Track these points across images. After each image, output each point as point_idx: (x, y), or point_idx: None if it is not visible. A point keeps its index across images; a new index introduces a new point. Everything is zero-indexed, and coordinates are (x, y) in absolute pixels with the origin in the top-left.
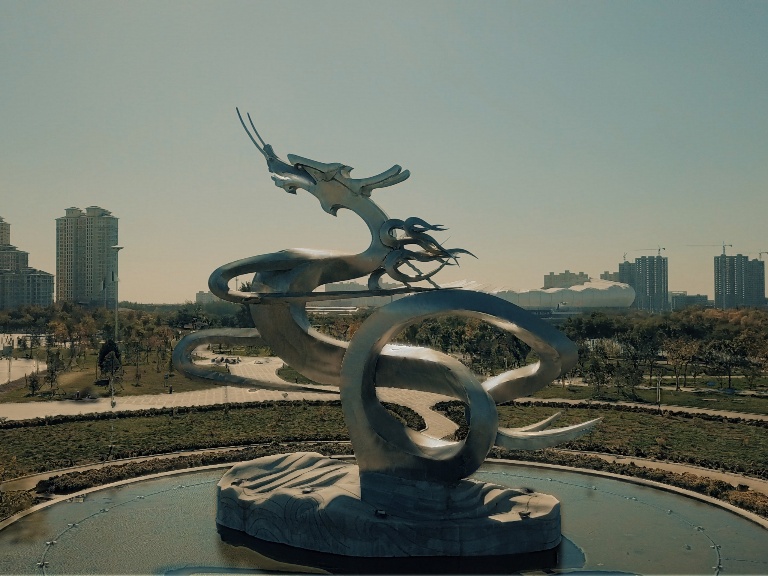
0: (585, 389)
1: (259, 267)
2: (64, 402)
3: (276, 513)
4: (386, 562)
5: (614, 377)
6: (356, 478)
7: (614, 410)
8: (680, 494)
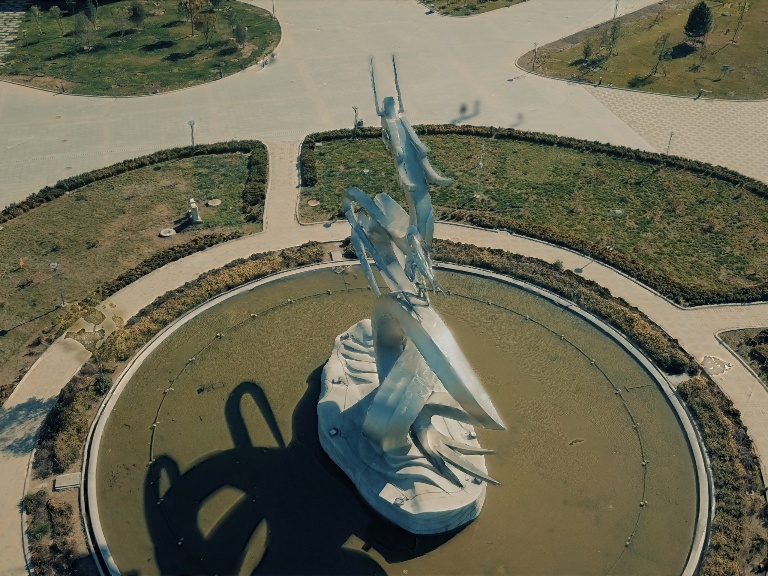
0: None
1: None
2: (577, 89)
3: None
4: (329, 460)
5: None
6: (369, 391)
7: None
8: (681, 574)
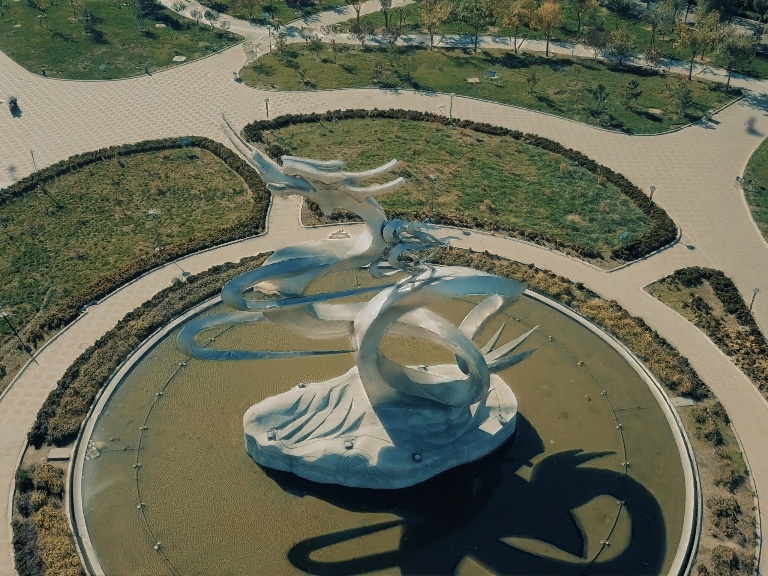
0: (359, 66)
1: (271, 277)
2: None
3: (329, 468)
4: None
5: (388, 57)
6: (375, 418)
7: (410, 120)
8: (543, 303)
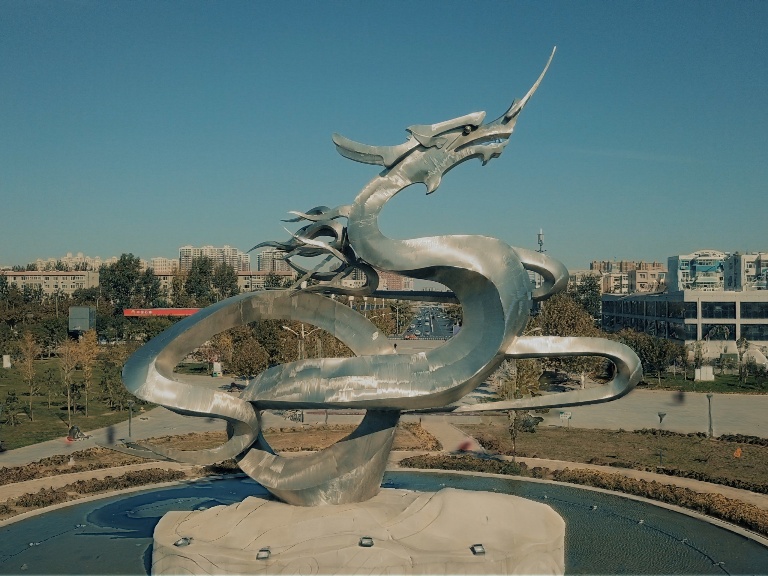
0: None
1: None
2: None
3: None
4: None
5: None
6: None
7: None
8: None
